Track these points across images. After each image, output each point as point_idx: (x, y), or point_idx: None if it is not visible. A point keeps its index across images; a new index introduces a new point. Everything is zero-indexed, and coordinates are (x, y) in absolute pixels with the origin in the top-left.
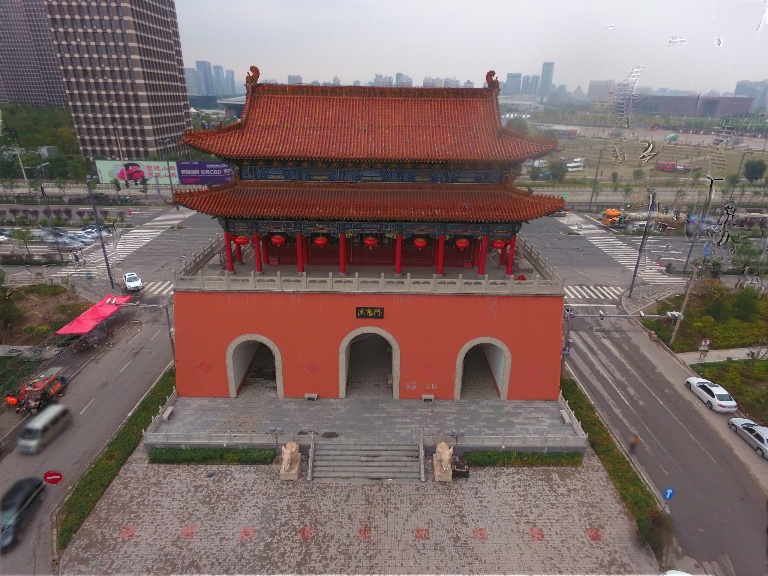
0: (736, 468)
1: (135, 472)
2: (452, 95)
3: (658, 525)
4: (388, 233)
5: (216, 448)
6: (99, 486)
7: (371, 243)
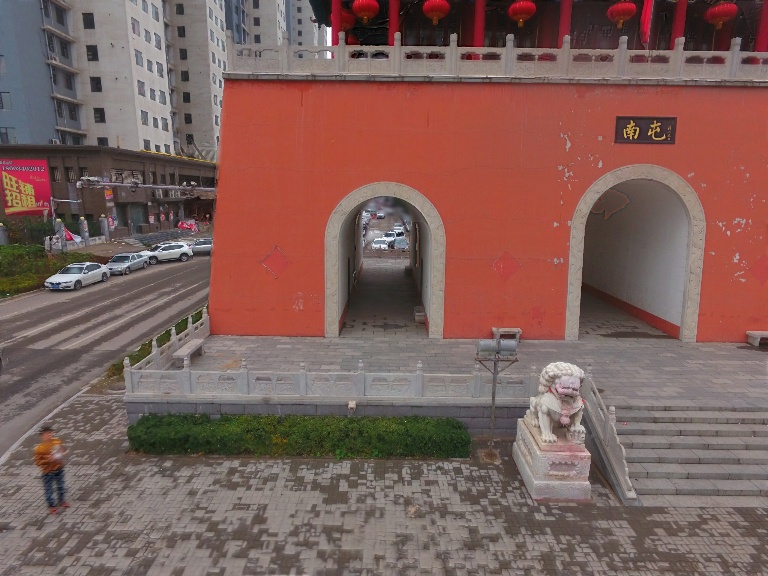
0: None
1: None
2: None
3: None
4: None
5: None
6: None
7: None
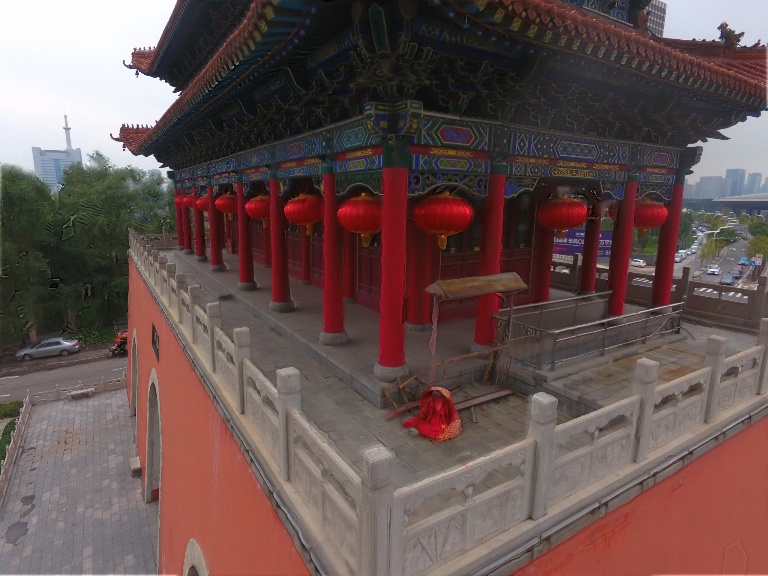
0: None
1: None
2: None
3: None
4: (234, 182)
5: None
6: None
7: (217, 203)
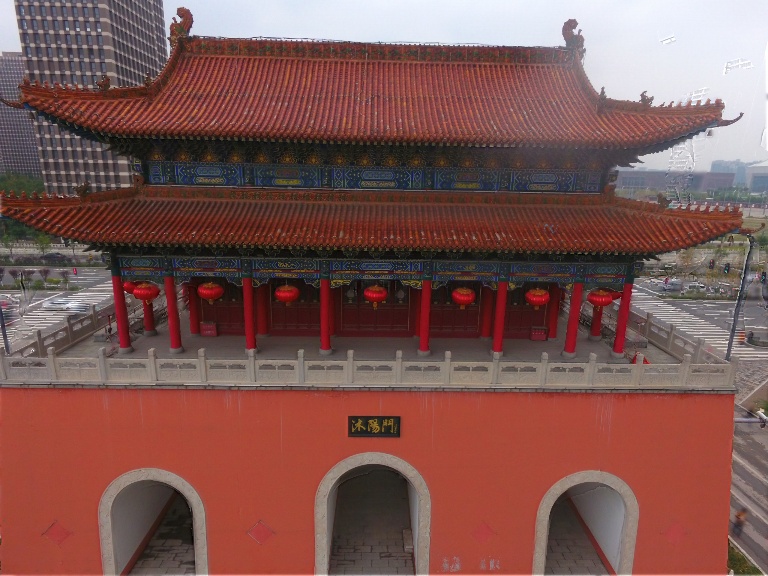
0: None
1: None
2: (508, 57)
3: None
4: (407, 279)
5: None
6: None
7: (376, 296)
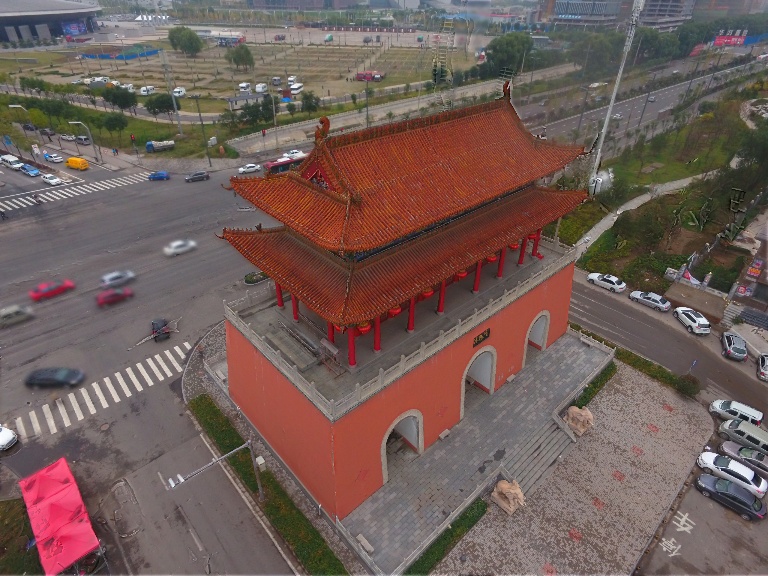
0: (659, 325)
1: None
2: (483, 109)
3: (696, 383)
4: None
5: (441, 535)
6: None
7: None
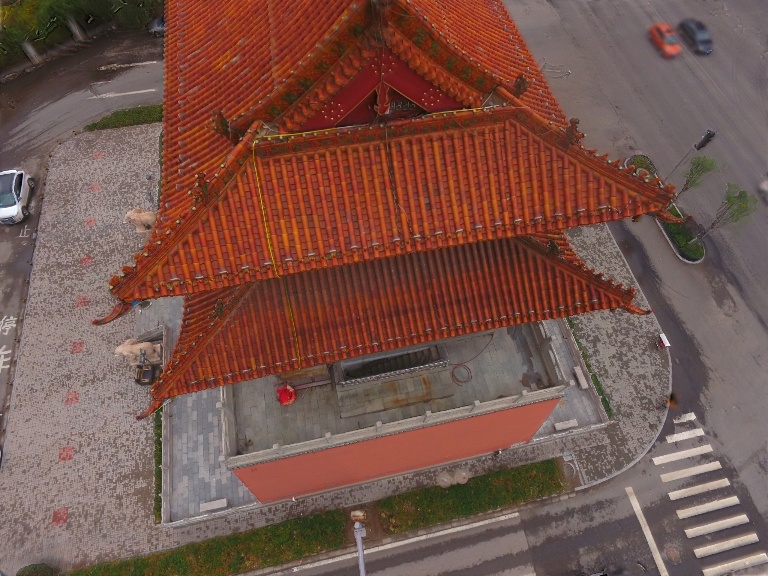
0: None
1: (153, 132)
2: None
3: None
4: None
5: None
6: (132, 119)
7: None
